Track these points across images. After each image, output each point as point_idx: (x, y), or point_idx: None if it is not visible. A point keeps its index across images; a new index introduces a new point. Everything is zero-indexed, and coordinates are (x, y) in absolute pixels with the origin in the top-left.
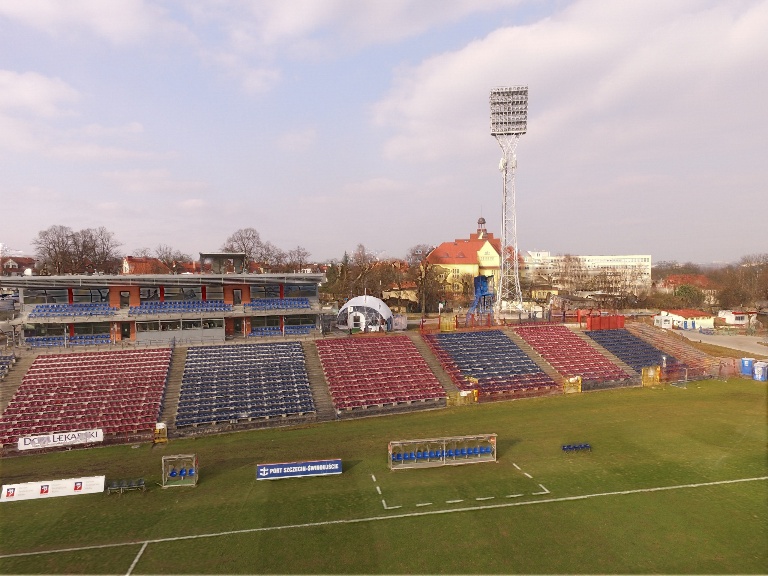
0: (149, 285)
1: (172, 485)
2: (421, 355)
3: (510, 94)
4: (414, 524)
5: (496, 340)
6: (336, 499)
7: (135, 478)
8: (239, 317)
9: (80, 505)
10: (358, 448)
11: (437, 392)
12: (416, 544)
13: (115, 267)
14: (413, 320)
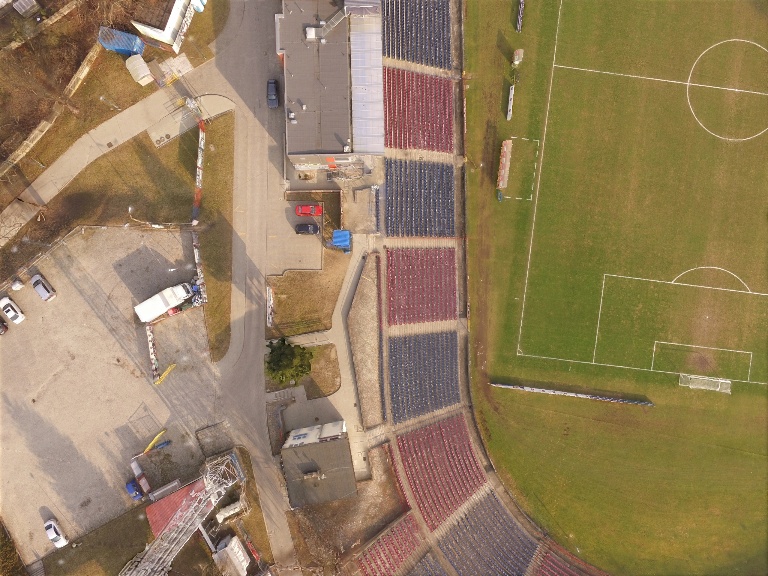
0: None
1: None
2: None
3: None
4: None
5: None
6: (546, 6)
7: (505, 79)
8: None
9: (522, 93)
10: None
11: None
12: None
13: None
14: None
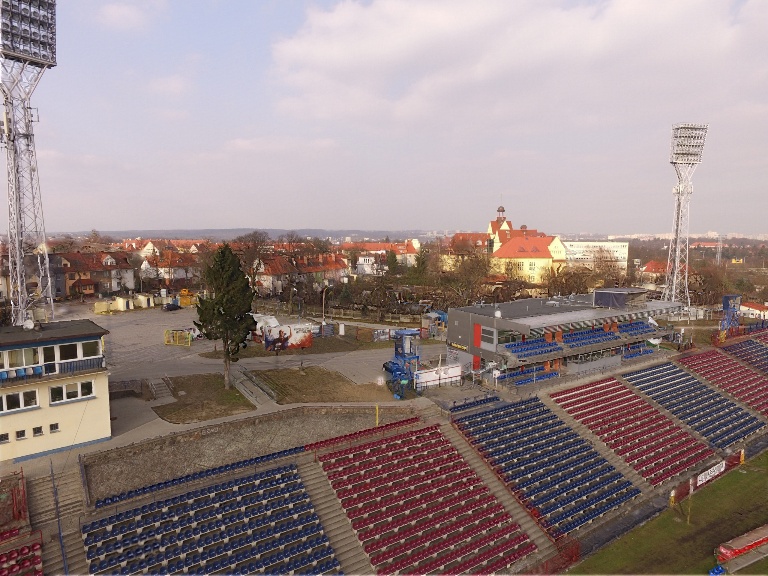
0: None
1: None
2: None
3: (694, 130)
4: None
5: (762, 349)
6: None
7: None
8: None
9: None
10: None
11: None
12: None
13: None
14: None
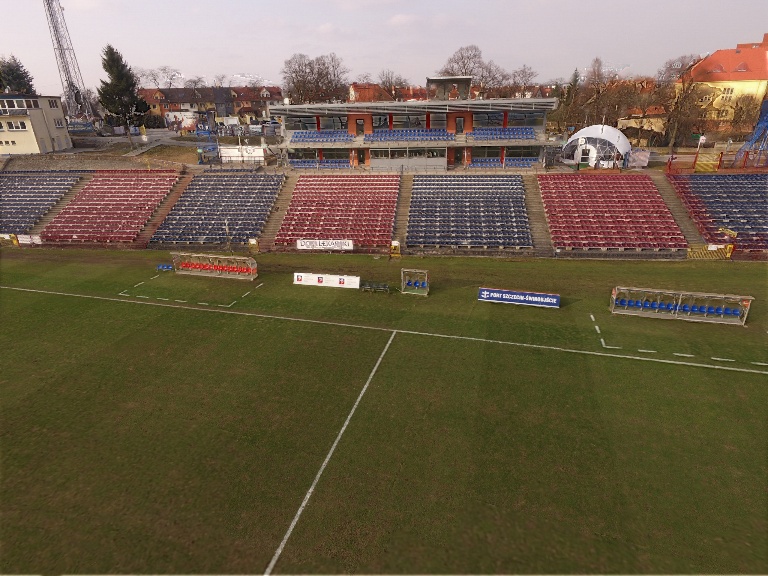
0: (381, 113)
1: (409, 292)
2: (663, 198)
3: None
4: (634, 366)
5: None
6: (553, 329)
7: (380, 282)
8: (460, 147)
9: (345, 295)
10: (577, 287)
11: (676, 242)
12: (635, 383)
13: (343, 94)
14: (655, 156)
